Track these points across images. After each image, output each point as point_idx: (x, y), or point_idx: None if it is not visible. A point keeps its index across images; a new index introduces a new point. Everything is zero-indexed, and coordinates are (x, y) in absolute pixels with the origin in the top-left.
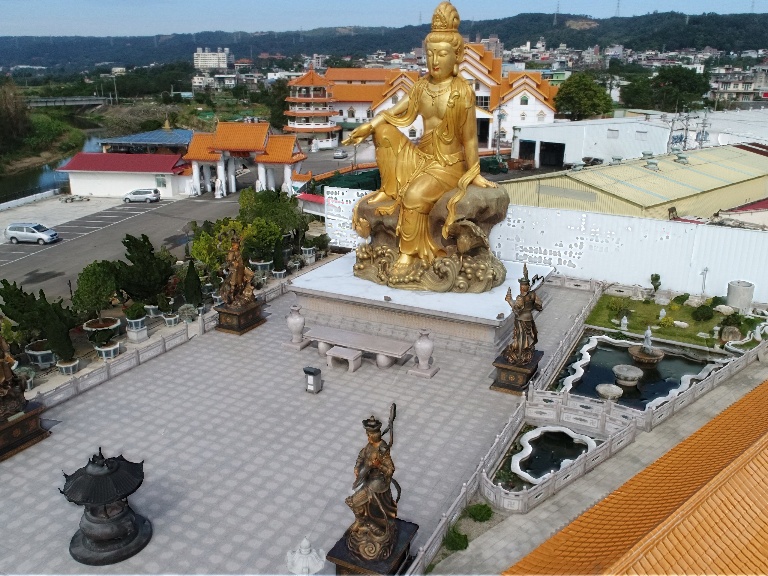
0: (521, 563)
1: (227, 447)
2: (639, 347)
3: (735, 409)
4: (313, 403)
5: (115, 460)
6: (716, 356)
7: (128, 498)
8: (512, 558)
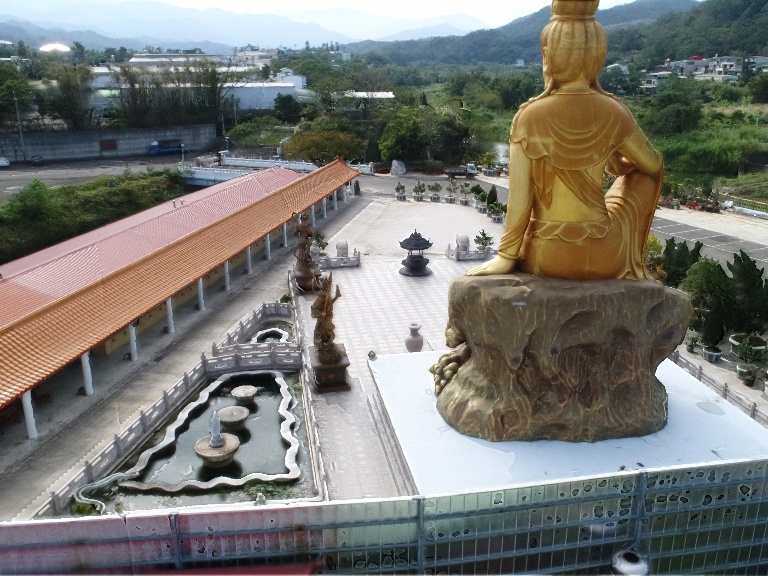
0: (240, 249)
1: (440, 297)
2: (228, 447)
3: (147, 305)
4: (444, 324)
5: (417, 239)
6: (122, 506)
7: (438, 278)
8: (259, 304)
